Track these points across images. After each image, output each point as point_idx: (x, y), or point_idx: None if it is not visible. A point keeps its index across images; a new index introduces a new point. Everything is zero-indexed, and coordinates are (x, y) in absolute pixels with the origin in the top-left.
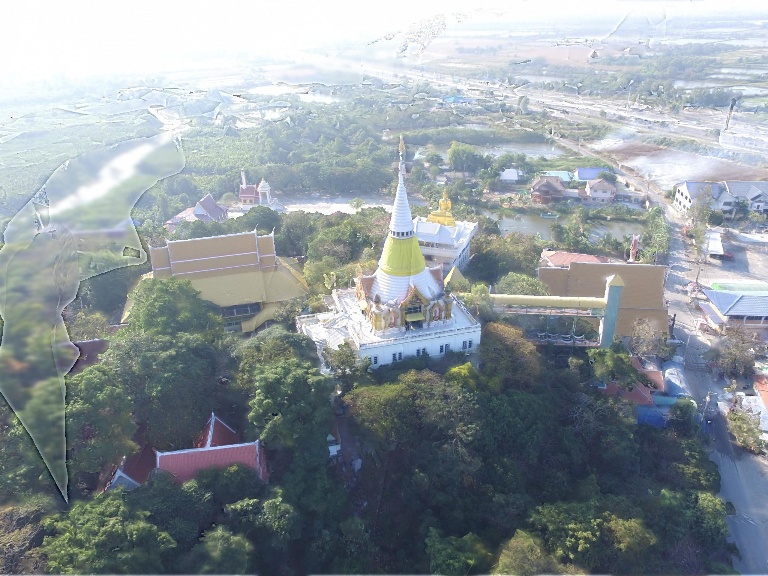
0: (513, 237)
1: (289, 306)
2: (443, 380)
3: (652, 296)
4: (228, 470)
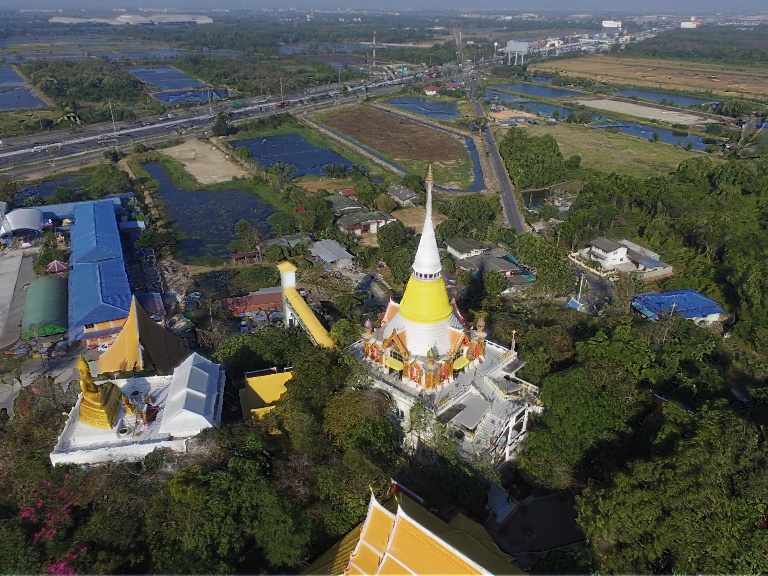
0: (40, 397)
1: (485, 453)
2: (500, 318)
3: (153, 324)
4: (690, 386)
